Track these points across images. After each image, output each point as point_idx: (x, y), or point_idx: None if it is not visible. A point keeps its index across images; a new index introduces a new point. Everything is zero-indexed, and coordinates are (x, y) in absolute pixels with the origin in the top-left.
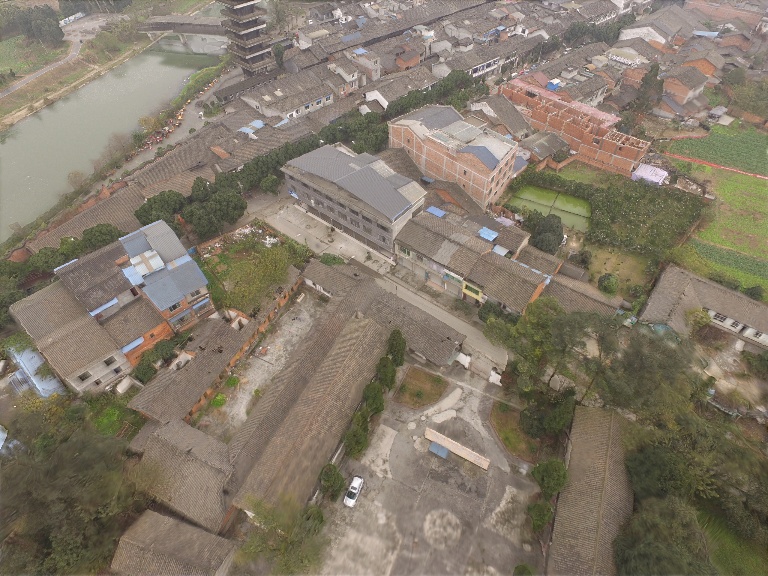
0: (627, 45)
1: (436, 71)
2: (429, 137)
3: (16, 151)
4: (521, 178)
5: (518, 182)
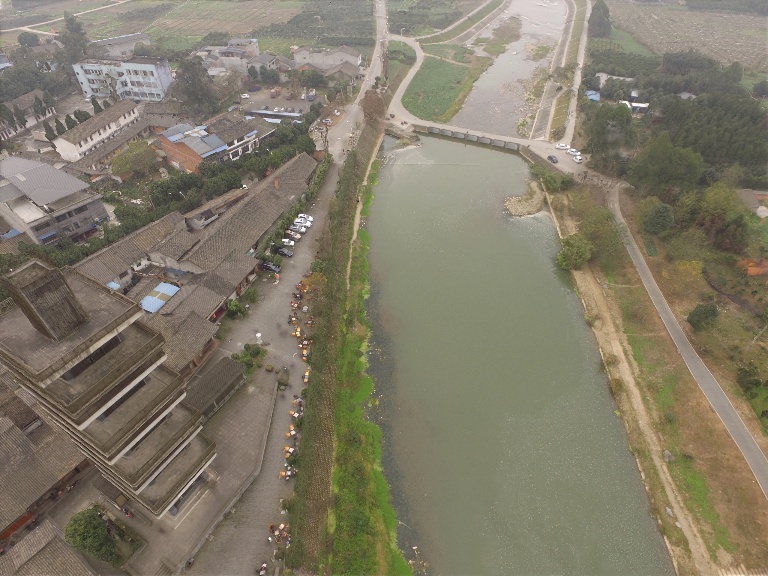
0: None
1: None
2: None
3: (508, 281)
4: None
5: None
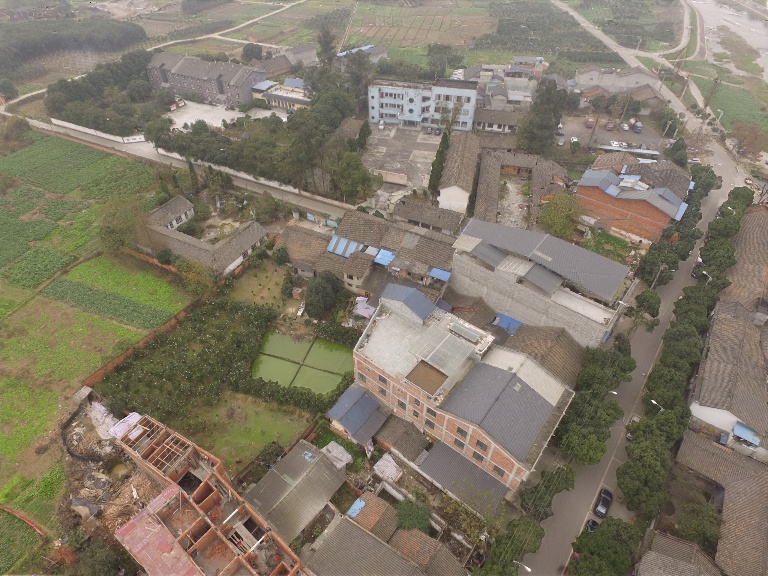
0: None
1: None
2: None
3: None
4: (340, 387)
5: (345, 379)
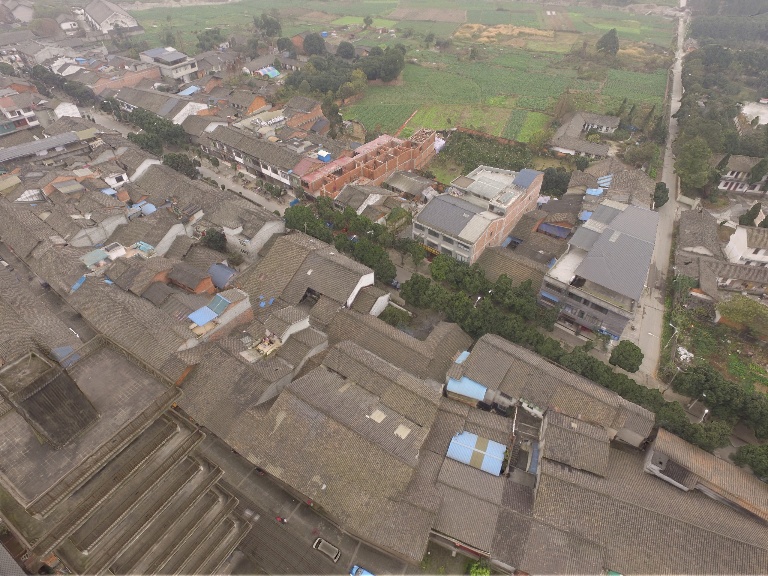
0: (207, 123)
1: (256, 242)
2: None
3: None
4: None
5: None
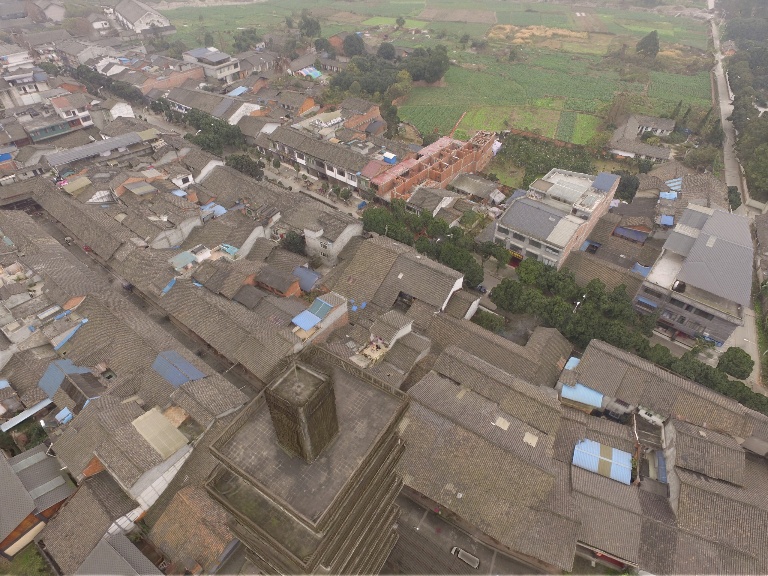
0: (263, 123)
1: (337, 245)
2: (595, 208)
3: None
4: None
5: None
